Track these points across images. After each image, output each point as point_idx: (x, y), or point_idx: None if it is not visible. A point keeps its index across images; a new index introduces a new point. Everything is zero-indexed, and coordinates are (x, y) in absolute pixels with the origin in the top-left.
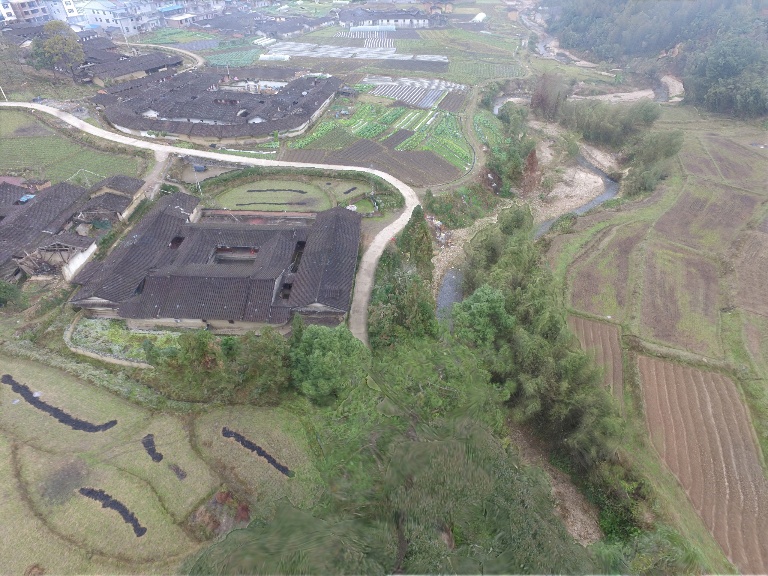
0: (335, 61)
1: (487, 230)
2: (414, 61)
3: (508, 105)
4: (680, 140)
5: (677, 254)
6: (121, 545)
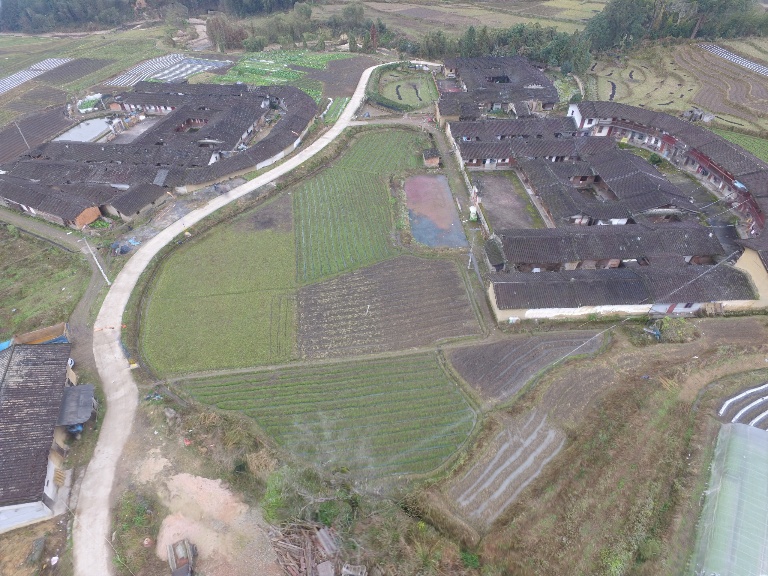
0: (4, 102)
1: None
2: (57, 69)
3: (252, 40)
4: None
5: None
6: None
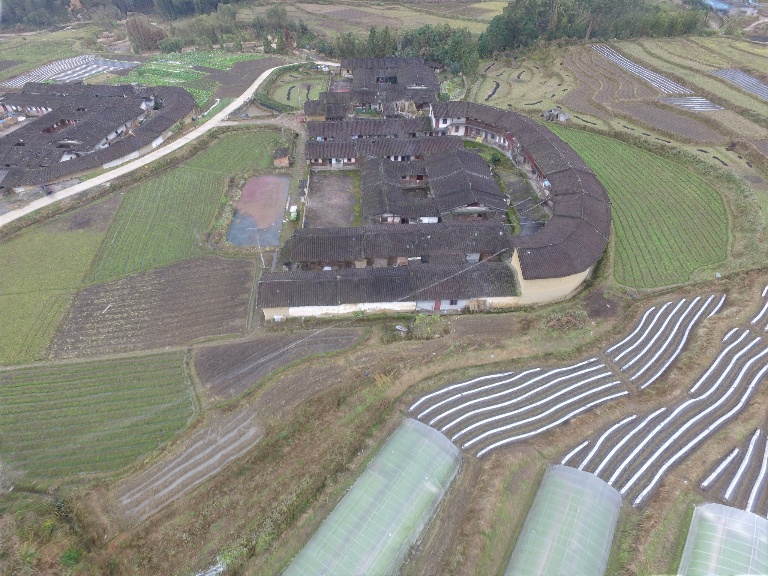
0: None
1: (360, 41)
2: None
3: (167, 41)
4: (284, 7)
5: None
6: None
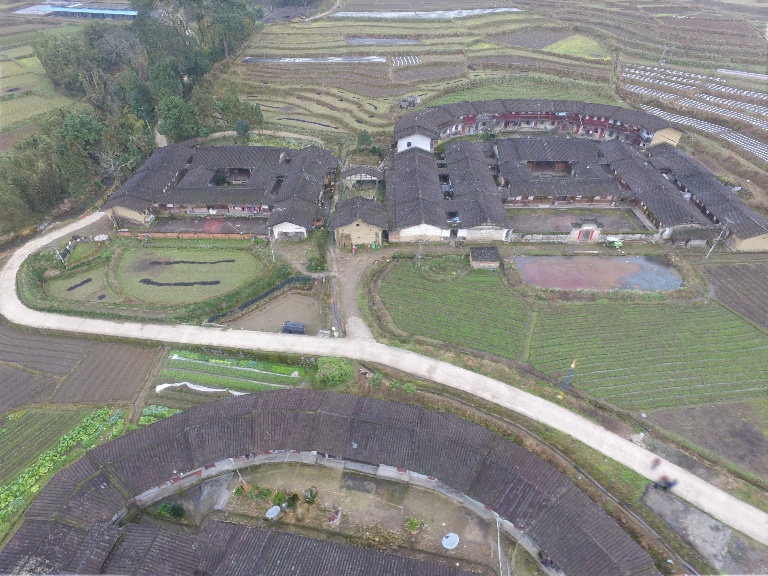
0: None
1: None
2: None
3: None
4: None
5: None
6: (262, 102)
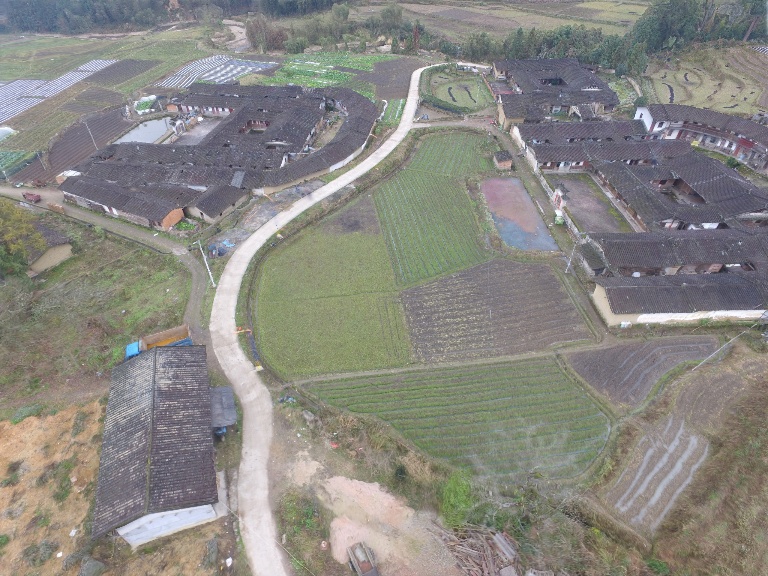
0: (60, 103)
1: (496, 42)
2: (105, 70)
3: (294, 41)
4: None
5: (481, 31)
6: None
